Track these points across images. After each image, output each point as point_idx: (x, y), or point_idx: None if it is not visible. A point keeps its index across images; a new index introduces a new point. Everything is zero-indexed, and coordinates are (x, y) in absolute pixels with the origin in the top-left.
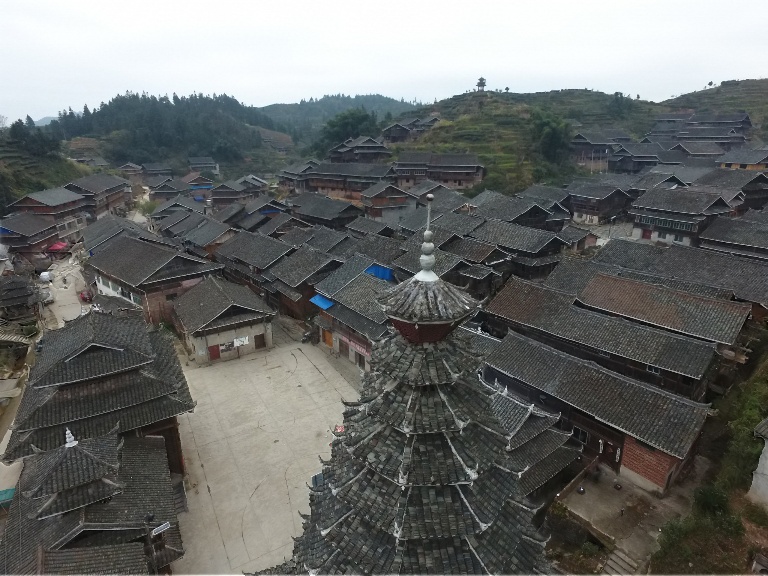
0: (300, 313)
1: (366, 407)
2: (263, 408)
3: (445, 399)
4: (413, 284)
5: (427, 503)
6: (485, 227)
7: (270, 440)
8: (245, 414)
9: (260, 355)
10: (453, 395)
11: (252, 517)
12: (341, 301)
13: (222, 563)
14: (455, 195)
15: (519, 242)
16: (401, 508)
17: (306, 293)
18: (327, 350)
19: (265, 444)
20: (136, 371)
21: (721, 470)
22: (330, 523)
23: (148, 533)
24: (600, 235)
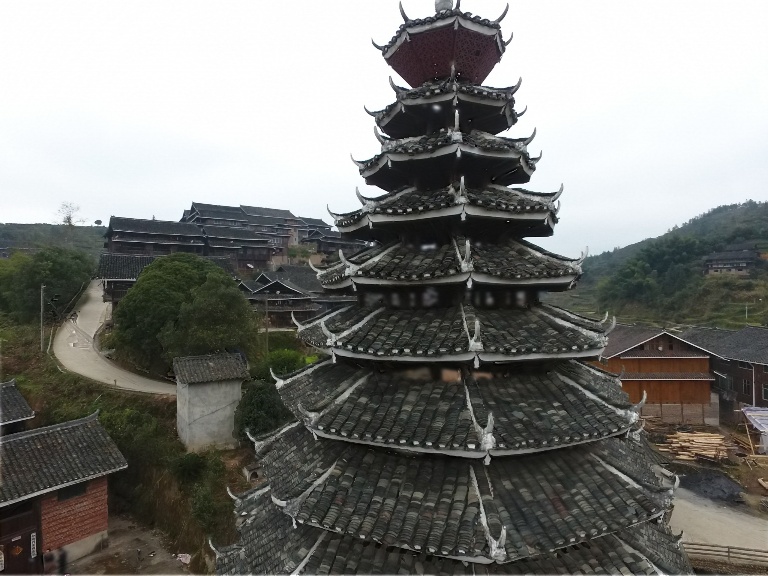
0: None
1: None
2: None
3: None
4: None
5: None
6: None
7: None
8: None
9: None
10: None
11: None
12: None
13: None
14: None
15: None
16: None
17: None
18: None
19: None
20: None
21: (155, 453)
22: None
23: None
24: None
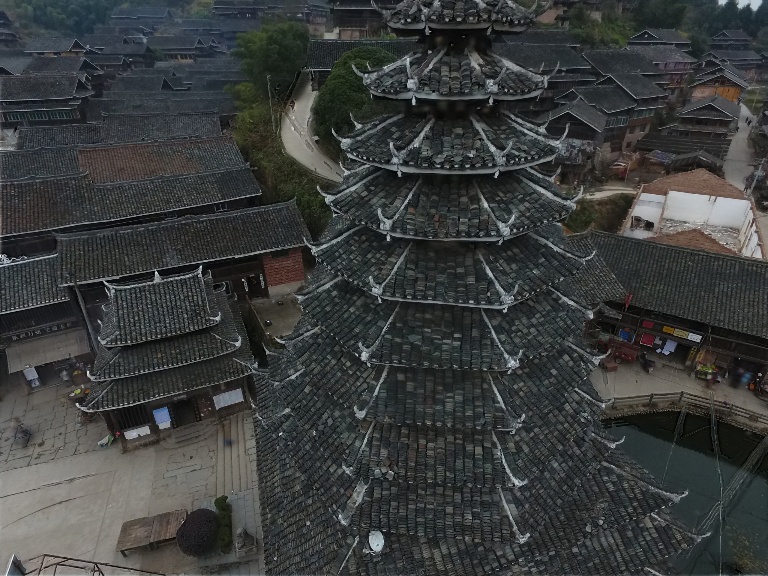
0: None
1: (497, 86)
2: None
3: None
4: None
5: None
6: None
7: None
8: None
9: None
10: None
11: None
12: None
13: None
14: None
15: None
16: None
17: None
18: None
19: None
20: None
21: None
22: (507, 282)
23: None
24: None
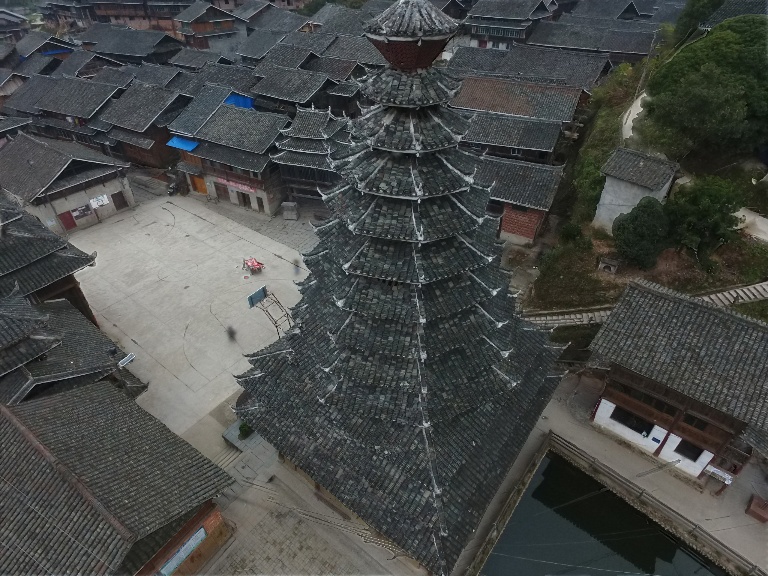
0: (156, 163)
1: (372, 141)
2: (156, 263)
3: (440, 121)
4: (404, 4)
5: (434, 215)
6: (338, 44)
7: (179, 288)
8: (138, 272)
9: (125, 215)
10: (443, 119)
11: (194, 350)
12: (207, 138)
13: (183, 390)
14: (290, 15)
15: (377, 56)
16: (418, 220)
17: (157, 138)
18: (202, 198)
19: (176, 292)
20: (2, 233)
21: (574, 212)
22: (350, 257)
23: (115, 366)
24: (445, 48)
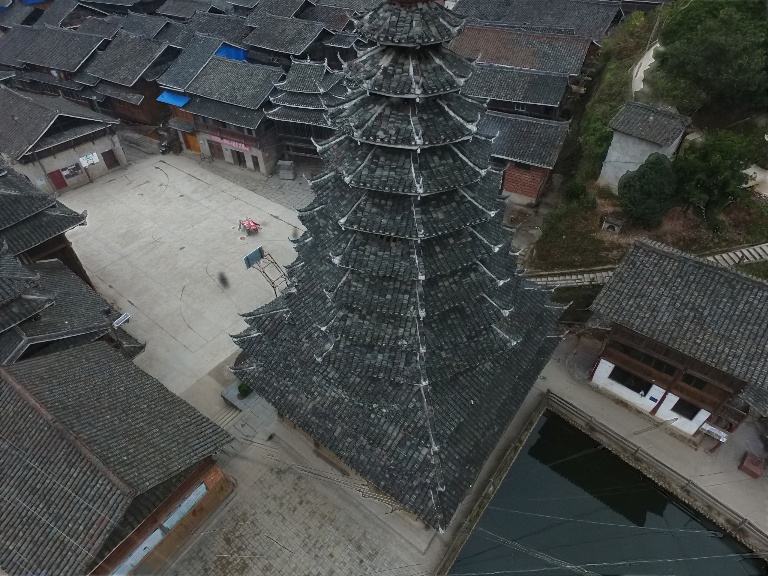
0: (147, 120)
1: (368, 85)
2: (151, 223)
3: (442, 63)
4: None
5: (435, 166)
6: None
7: (175, 249)
8: (133, 233)
9: (117, 175)
10: (445, 61)
11: (191, 312)
12: (199, 93)
13: (181, 351)
14: None
15: None
16: (417, 171)
17: (147, 93)
18: (196, 157)
19: (171, 253)
20: None
21: (579, 170)
22: (346, 212)
23: (110, 326)
24: None
